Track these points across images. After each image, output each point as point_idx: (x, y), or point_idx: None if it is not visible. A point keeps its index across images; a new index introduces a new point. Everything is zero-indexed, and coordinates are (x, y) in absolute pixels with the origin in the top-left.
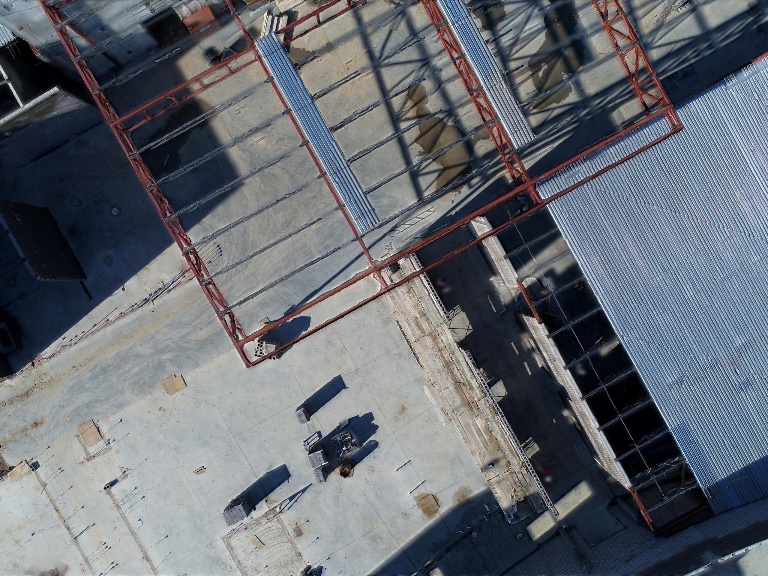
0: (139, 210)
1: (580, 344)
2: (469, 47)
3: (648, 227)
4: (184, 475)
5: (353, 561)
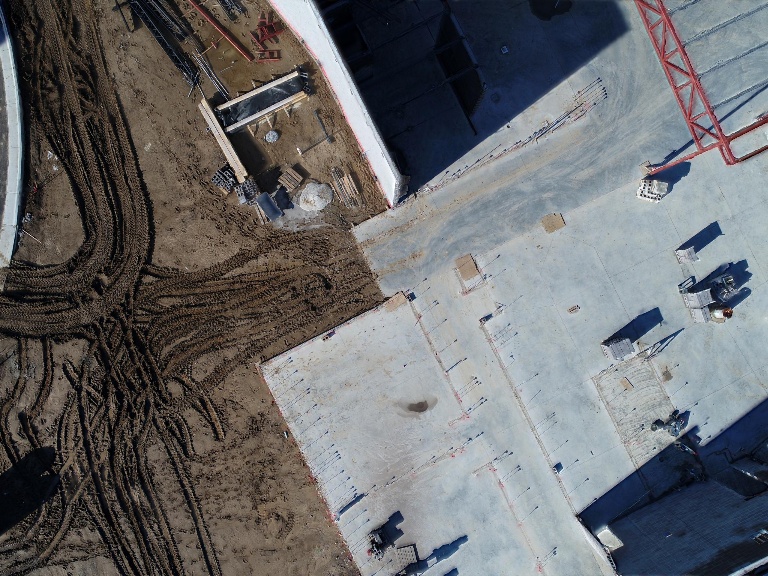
0: (528, 50)
1: None
2: None
3: None
4: (558, 313)
5: (721, 408)
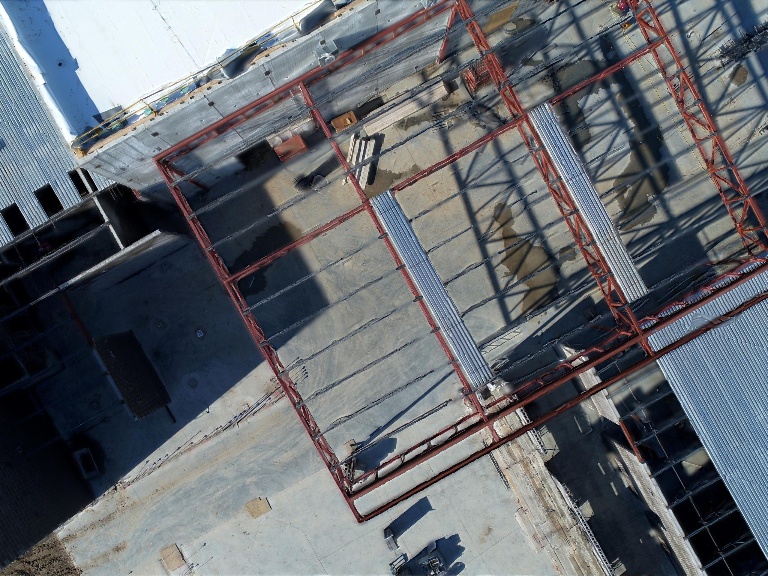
0: (224, 332)
1: (681, 482)
2: (583, 204)
3: (749, 366)
4: None
5: None
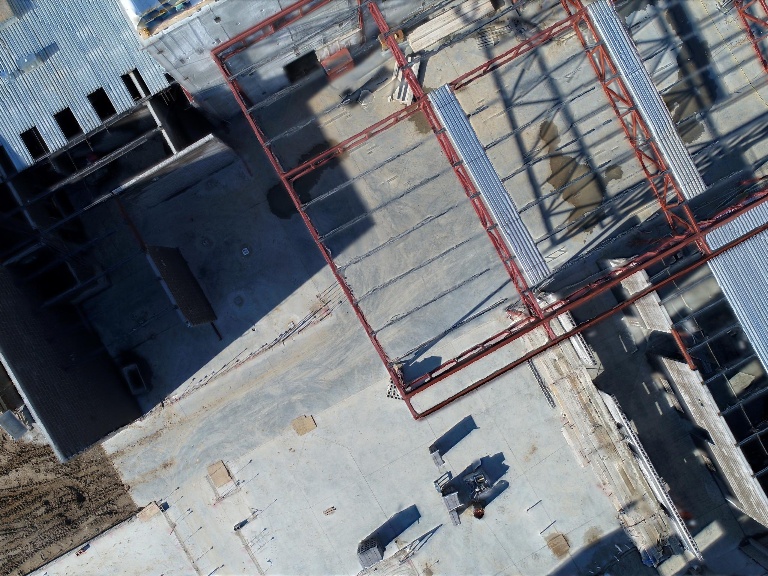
0: (270, 250)
1: (732, 390)
2: (642, 98)
3: None
4: (314, 516)
5: None
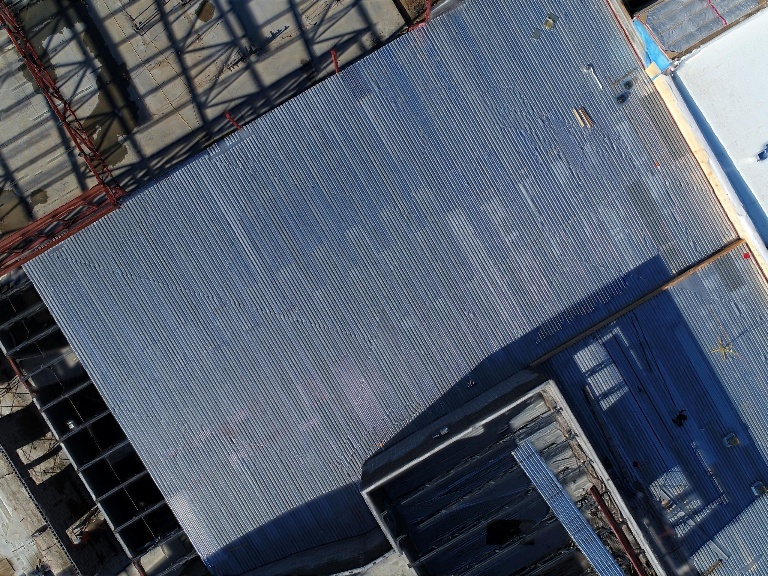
0: None
1: (80, 416)
2: None
3: (135, 299)
4: None
5: None
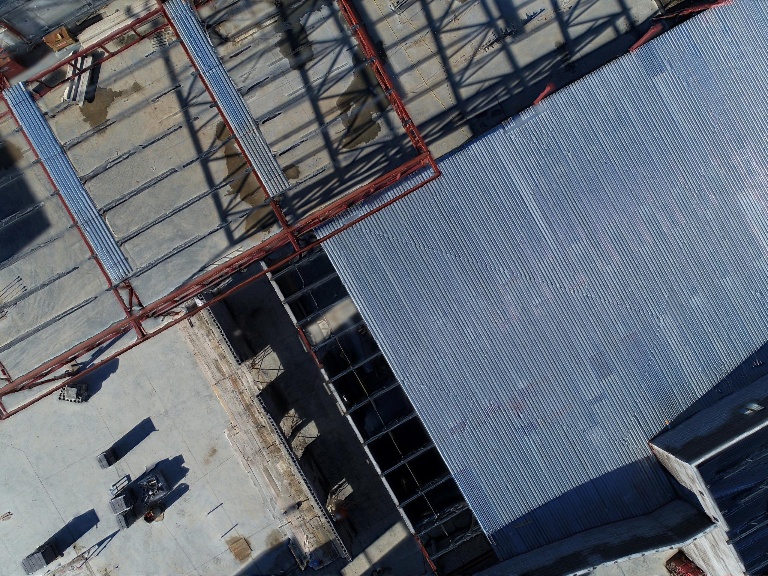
0: None
1: (364, 389)
2: (220, 96)
3: (428, 271)
4: None
5: None
